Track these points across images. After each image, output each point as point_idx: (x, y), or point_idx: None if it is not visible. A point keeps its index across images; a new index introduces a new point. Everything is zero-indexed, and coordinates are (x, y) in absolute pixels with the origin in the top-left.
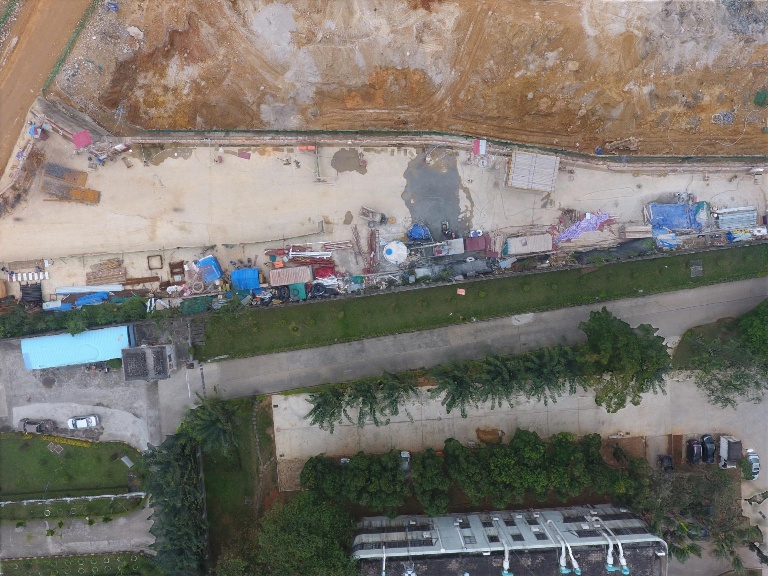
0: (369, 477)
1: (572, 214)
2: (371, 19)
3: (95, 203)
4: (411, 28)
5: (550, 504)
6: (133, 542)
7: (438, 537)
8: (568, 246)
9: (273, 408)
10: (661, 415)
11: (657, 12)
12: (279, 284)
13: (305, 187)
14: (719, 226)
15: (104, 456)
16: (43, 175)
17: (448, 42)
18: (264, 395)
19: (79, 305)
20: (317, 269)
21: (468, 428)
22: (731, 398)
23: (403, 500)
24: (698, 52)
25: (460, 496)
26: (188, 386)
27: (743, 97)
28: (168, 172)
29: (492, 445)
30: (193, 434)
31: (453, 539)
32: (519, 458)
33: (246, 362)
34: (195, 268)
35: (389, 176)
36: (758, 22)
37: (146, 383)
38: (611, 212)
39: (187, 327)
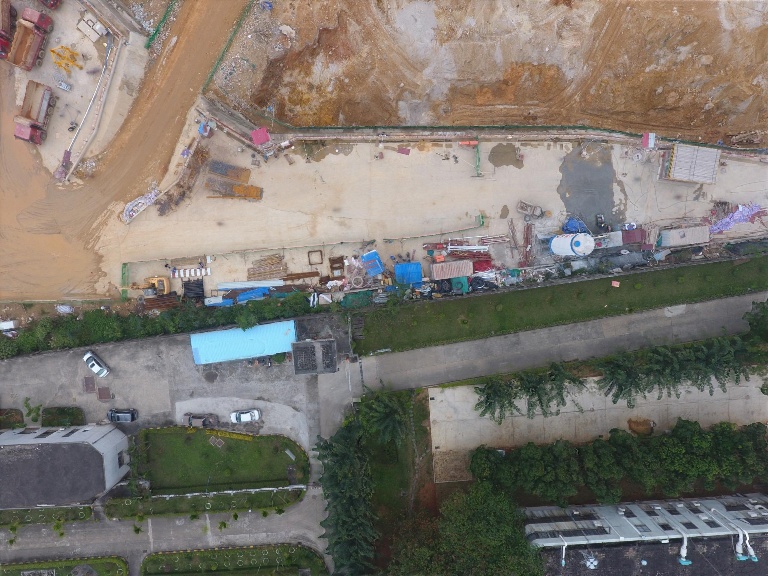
0: (545, 467)
1: (725, 206)
2: (513, 15)
3: (257, 200)
4: (552, 24)
5: (699, 493)
6: (291, 534)
7: (610, 526)
8: (720, 238)
9: (429, 401)
10: None
11: None
12: (442, 278)
13: (463, 182)
14: None
15: (264, 449)
16: (207, 172)
17: (586, 37)
18: (422, 388)
19: (240, 300)
20: (474, 263)
21: (620, 419)
22: None
23: (576, 489)
24: None
25: (633, 485)
26: (349, 379)
27: None
28: (329, 168)
29: (644, 435)
30: (368, 426)
31: (625, 528)
32: (686, 447)
33: (404, 355)
34: (354, 263)
35: (545, 170)
36: None
37: (306, 377)
38: (762, 204)
39: (347, 321)
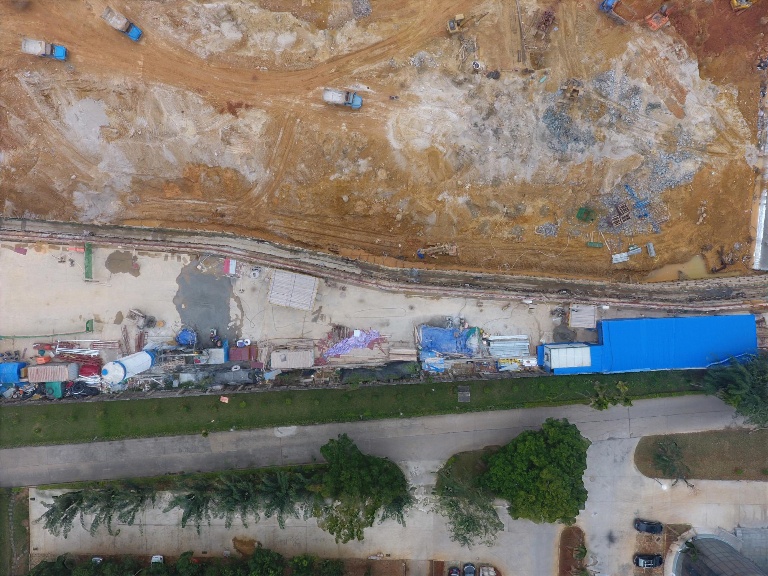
0: None
1: (340, 331)
2: (178, 120)
3: None
4: (217, 131)
5: None
6: None
7: None
8: (336, 361)
9: (30, 501)
10: (423, 539)
11: (463, 130)
12: (37, 381)
13: (78, 285)
14: (490, 353)
15: None
16: None
17: (256, 145)
18: (20, 487)
19: None
20: (83, 366)
21: (225, 536)
22: (467, 537)
23: None
24: (514, 167)
25: None
26: None
27: (566, 211)
28: None
29: (247, 556)
30: None
31: None
32: None
33: (6, 453)
34: None
35: (162, 280)
36: (578, 141)
37: None
38: (382, 331)
39: None
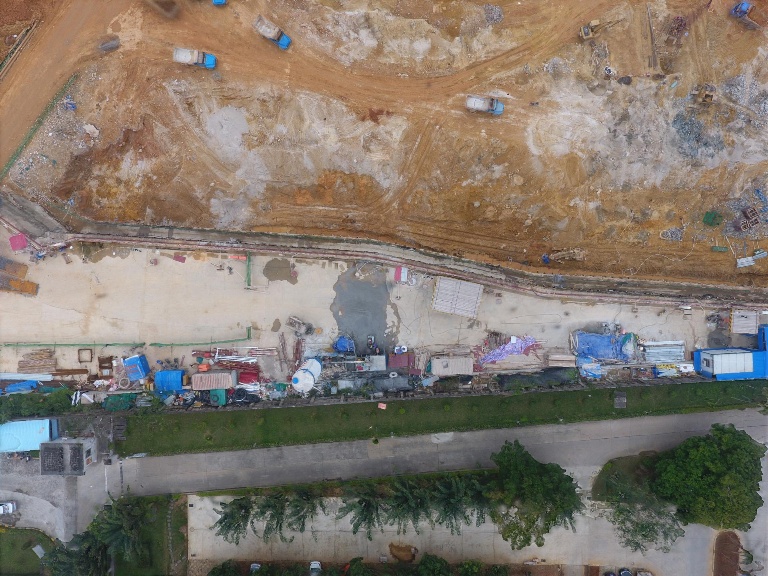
0: None
1: (497, 337)
2: (320, 127)
3: (33, 295)
4: (359, 138)
5: None
6: None
7: None
8: (492, 368)
9: (188, 507)
10: (578, 544)
11: (602, 136)
12: (201, 388)
13: (236, 293)
14: (646, 358)
15: (19, 542)
16: None
17: (395, 152)
18: (180, 494)
19: (9, 392)
20: (241, 374)
21: (381, 542)
22: (640, 543)
23: None
24: (646, 172)
25: None
26: (105, 480)
27: (692, 216)
28: (105, 270)
29: (404, 562)
30: (99, 536)
31: None
32: None
33: (165, 460)
34: (123, 364)
35: (319, 288)
36: (708, 146)
37: None
38: (537, 337)
39: (110, 421)
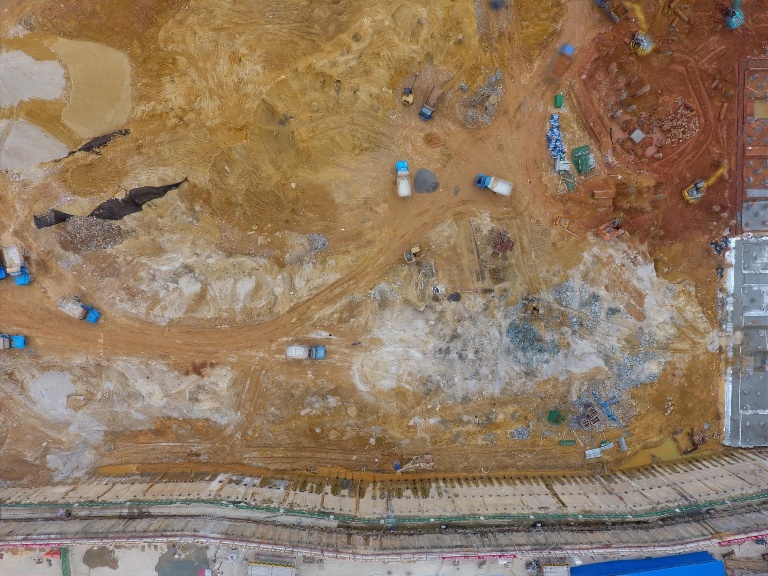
0: None
1: None
2: (144, 386)
3: None
4: (184, 392)
5: None
6: None
7: None
8: None
9: None
10: None
11: (428, 367)
12: None
13: None
14: None
15: None
16: None
17: (224, 398)
18: None
19: None
20: None
21: None
22: None
23: None
24: (482, 386)
25: None
26: None
27: (537, 414)
28: None
29: None
30: None
31: None
32: None
33: None
34: None
35: (141, 570)
36: (543, 352)
37: None
38: None
39: None
